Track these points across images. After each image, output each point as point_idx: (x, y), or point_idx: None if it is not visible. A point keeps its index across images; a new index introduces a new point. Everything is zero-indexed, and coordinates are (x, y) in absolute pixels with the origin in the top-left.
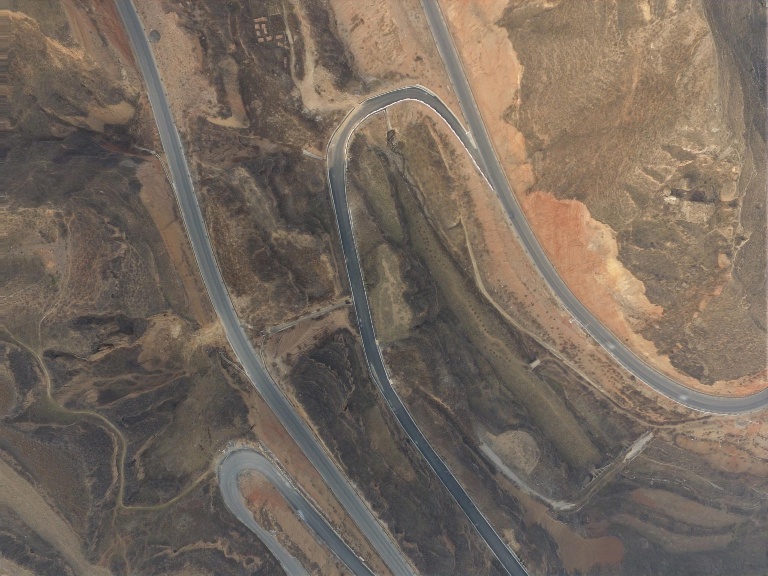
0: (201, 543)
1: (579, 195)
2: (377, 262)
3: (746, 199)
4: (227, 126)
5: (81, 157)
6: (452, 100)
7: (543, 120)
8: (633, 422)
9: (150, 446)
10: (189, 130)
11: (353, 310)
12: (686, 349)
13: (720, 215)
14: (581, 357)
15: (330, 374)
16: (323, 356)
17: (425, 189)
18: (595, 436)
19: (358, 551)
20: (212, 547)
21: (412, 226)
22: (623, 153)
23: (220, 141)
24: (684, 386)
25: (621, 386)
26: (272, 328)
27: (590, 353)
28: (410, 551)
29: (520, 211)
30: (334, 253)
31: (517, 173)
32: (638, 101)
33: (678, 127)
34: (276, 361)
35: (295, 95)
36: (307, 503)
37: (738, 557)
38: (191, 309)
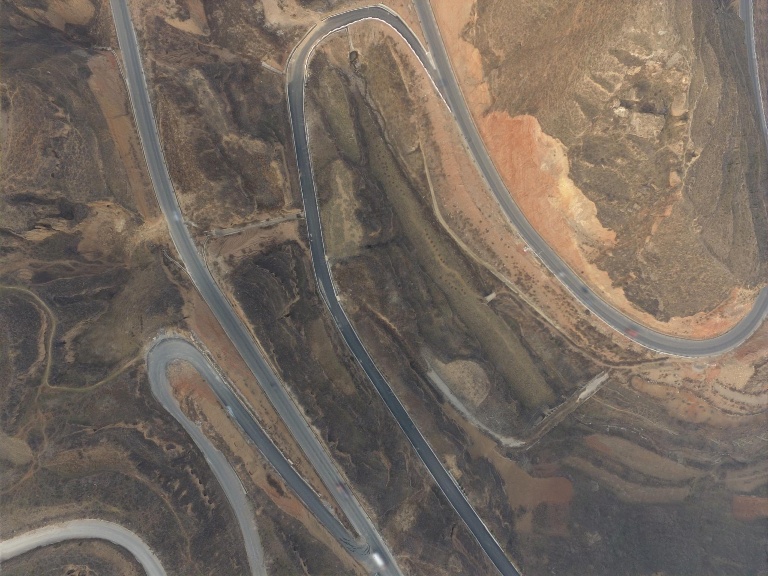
0: (122, 424)
1: (531, 109)
2: (331, 178)
3: (697, 114)
4: (186, 31)
5: (35, 43)
6: (413, 19)
7: (498, 33)
8: (588, 361)
9: (83, 332)
10: (146, 28)
11: (304, 224)
12: (640, 279)
13: (671, 131)
14: (536, 289)
15: (273, 279)
16: (268, 262)
17: (385, 113)
18: (550, 377)
19: (287, 454)
20: (132, 427)
21: (371, 150)
22: (573, 61)
23: (178, 44)
24: (640, 324)
25: (576, 321)
26: (218, 231)
27: (544, 284)
28: (341, 459)
29: (478, 135)
30: (287, 164)
31: (475, 95)
32: (588, 7)
33: (625, 29)
34: (218, 260)
35: (258, 8)
36: (237, 399)
37: (695, 512)
38: (133, 199)
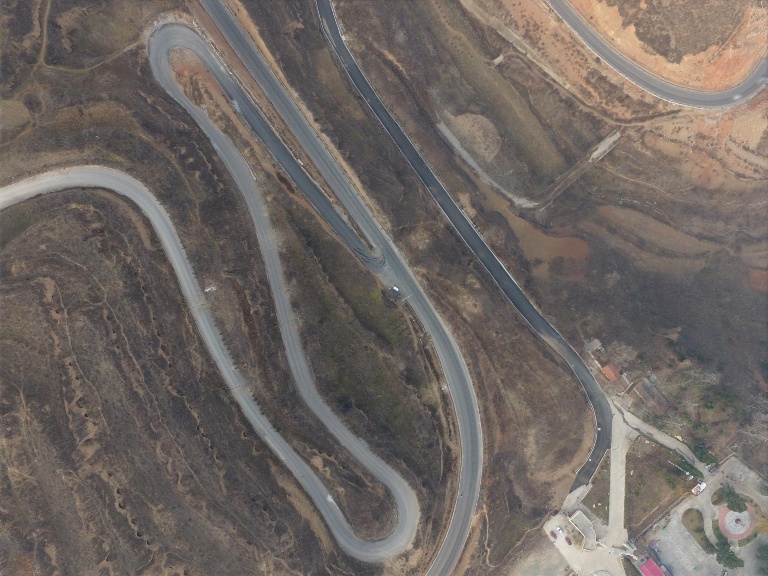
0: None
1: None
2: None
3: None
4: None
5: None
6: None
7: None
8: (599, 121)
9: None
10: None
11: None
12: (651, 7)
13: None
14: (544, 40)
15: None
16: None
17: None
18: (561, 147)
19: (297, 155)
20: None
21: None
22: None
23: None
24: (652, 74)
25: (586, 73)
26: None
27: (553, 32)
28: (353, 164)
29: None
30: None
31: None
32: None
33: None
34: None
35: None
36: (243, 93)
37: (711, 281)
38: None
